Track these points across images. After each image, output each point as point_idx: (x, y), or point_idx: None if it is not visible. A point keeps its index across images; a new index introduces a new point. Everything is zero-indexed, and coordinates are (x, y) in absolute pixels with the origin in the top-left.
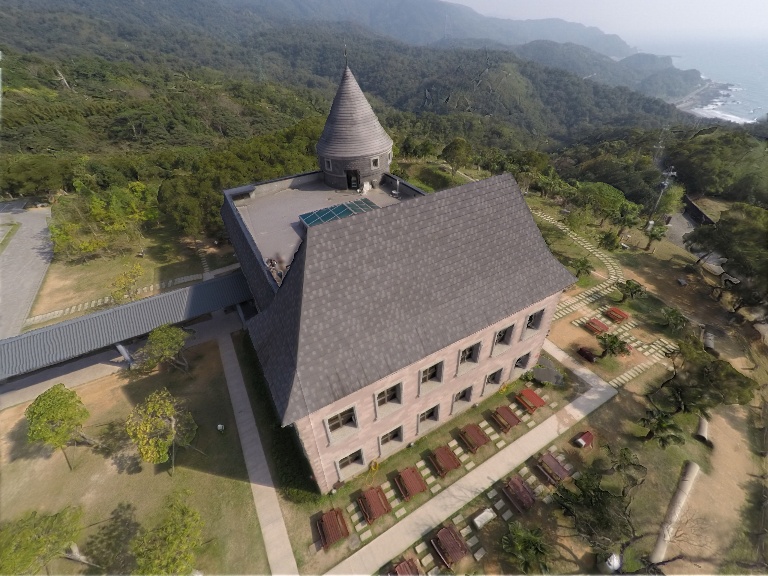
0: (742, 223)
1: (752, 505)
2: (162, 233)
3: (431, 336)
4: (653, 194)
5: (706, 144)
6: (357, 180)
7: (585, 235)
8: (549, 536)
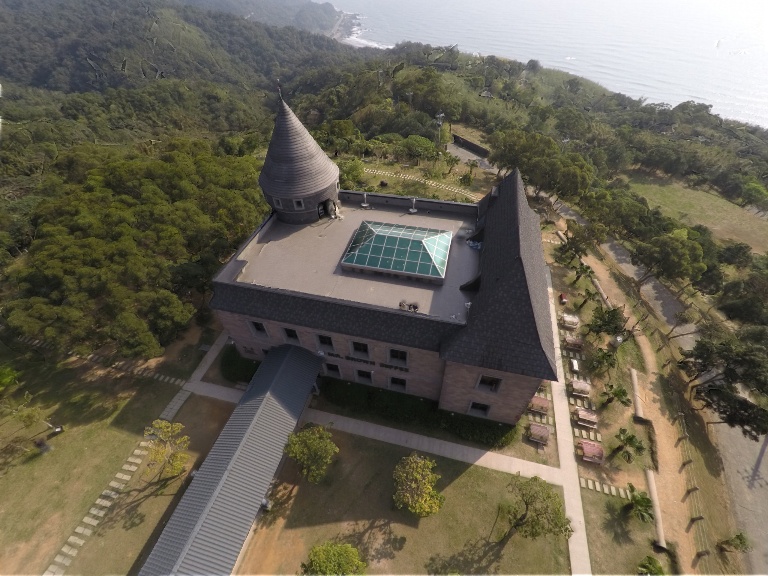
0: (518, 143)
1: (618, 282)
2: (39, 390)
3: (543, 286)
4: (434, 132)
5: (418, 81)
6: (324, 208)
7: (450, 181)
8: (595, 350)
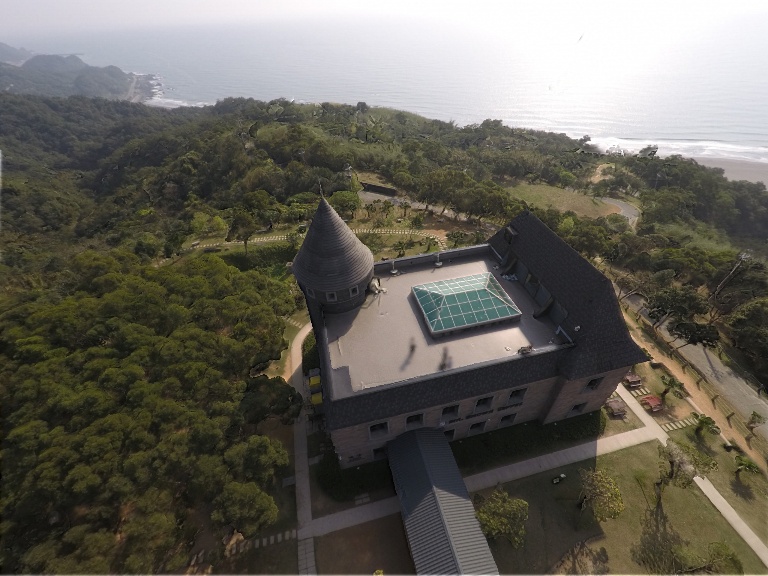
0: (440, 181)
1: None
2: None
3: None
4: (346, 184)
5: (291, 138)
6: None
7: None
8: None
